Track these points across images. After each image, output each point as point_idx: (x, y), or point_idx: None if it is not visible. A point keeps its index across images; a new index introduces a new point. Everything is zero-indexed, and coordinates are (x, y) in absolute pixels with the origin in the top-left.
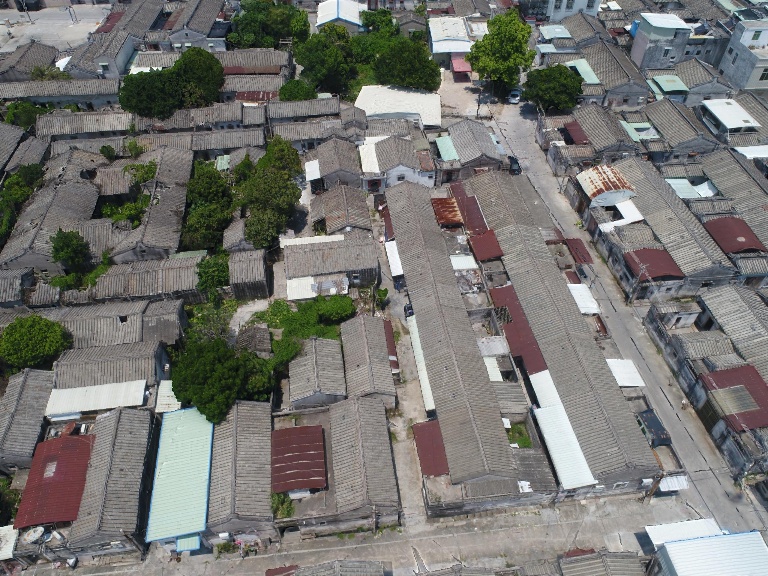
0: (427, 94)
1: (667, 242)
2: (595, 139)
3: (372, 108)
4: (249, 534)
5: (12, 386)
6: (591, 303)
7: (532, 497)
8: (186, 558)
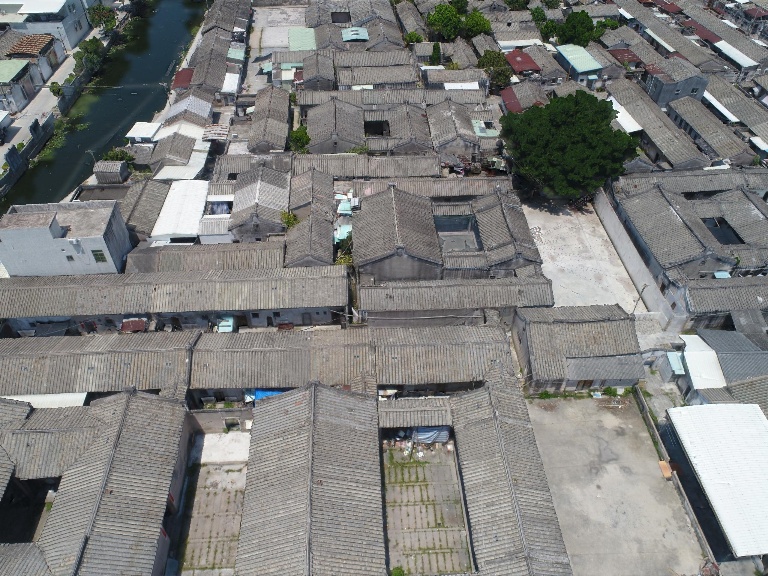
0: None
1: (765, 7)
2: None
3: None
4: (612, 81)
5: (477, 40)
6: (734, 25)
7: (729, 74)
8: None
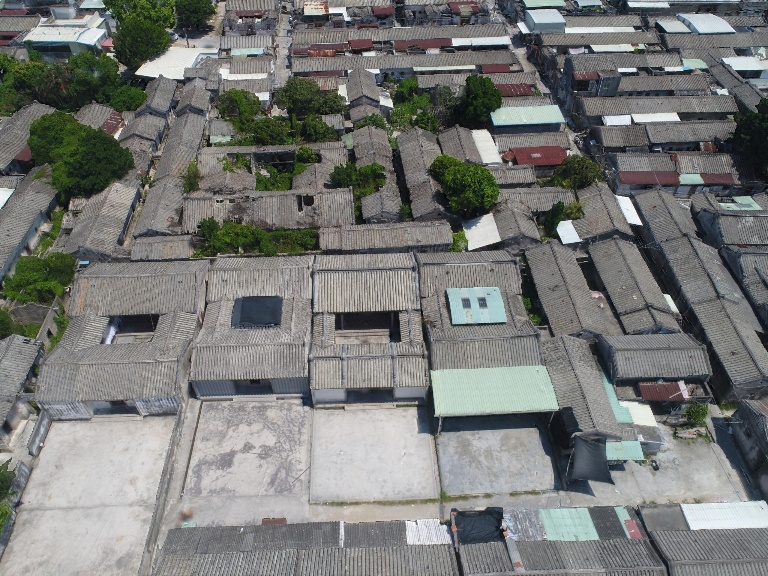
0: (169, 50)
1: (368, 4)
2: (264, 7)
3: (180, 69)
4: None
5: None
6: (407, 27)
7: None
8: None
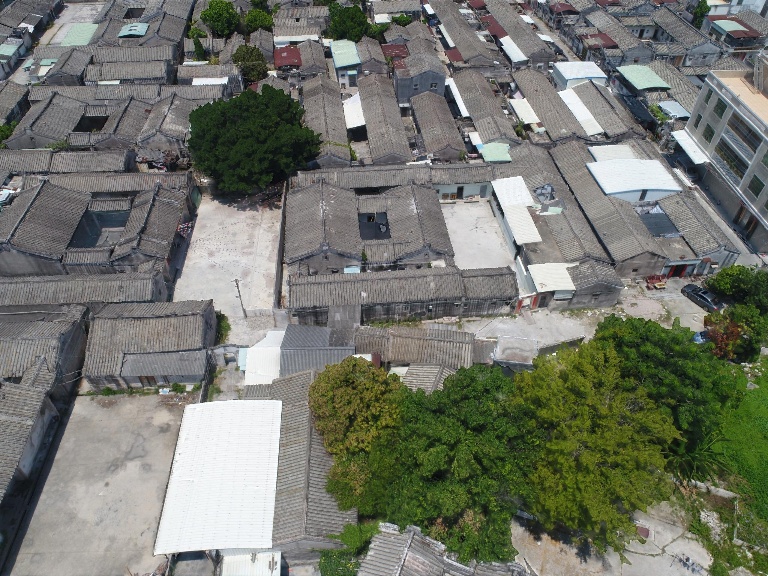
0: None
1: (572, 2)
2: None
3: None
4: None
5: (254, 35)
6: (531, 21)
7: (500, 70)
8: (348, 88)
